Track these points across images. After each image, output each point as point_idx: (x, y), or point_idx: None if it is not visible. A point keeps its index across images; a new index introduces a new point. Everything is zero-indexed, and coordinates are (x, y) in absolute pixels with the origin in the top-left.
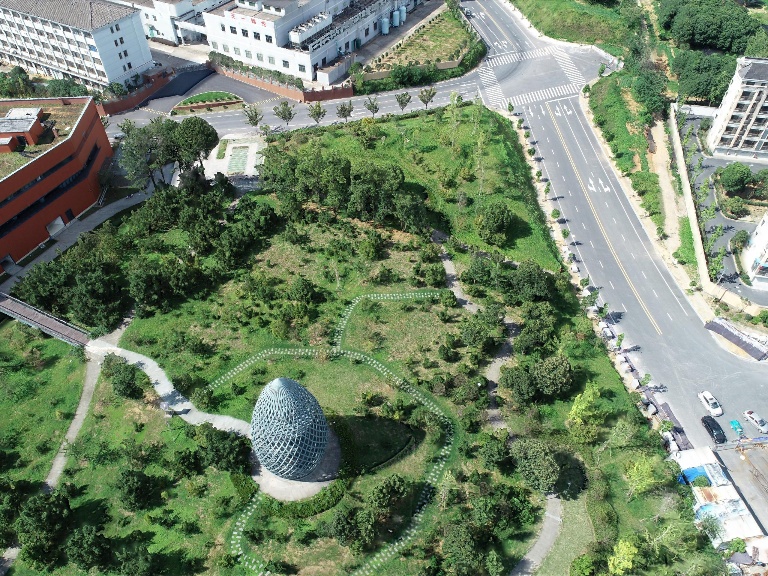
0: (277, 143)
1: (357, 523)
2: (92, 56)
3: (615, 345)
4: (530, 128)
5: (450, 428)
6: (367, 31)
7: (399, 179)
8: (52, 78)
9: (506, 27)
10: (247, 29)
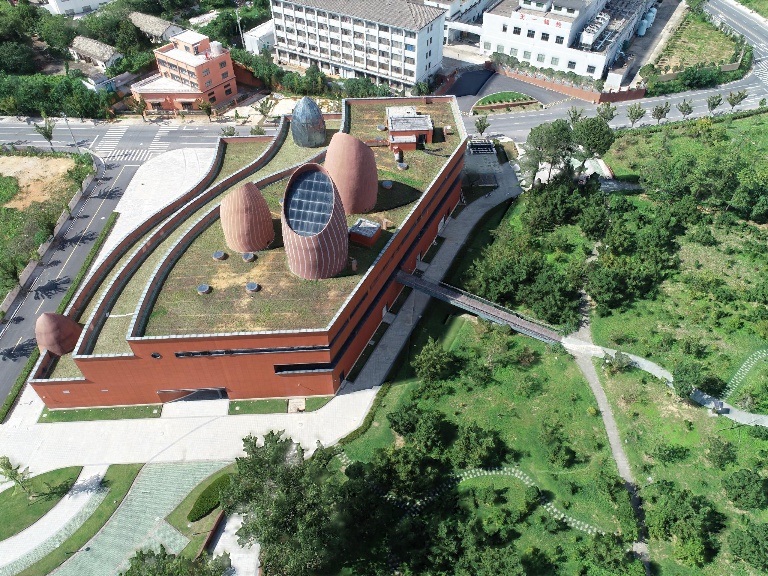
0: None
1: None
2: (405, 55)
3: None
4: None
5: None
6: (629, 33)
7: None
8: (339, 77)
9: (754, 30)
10: (535, 30)
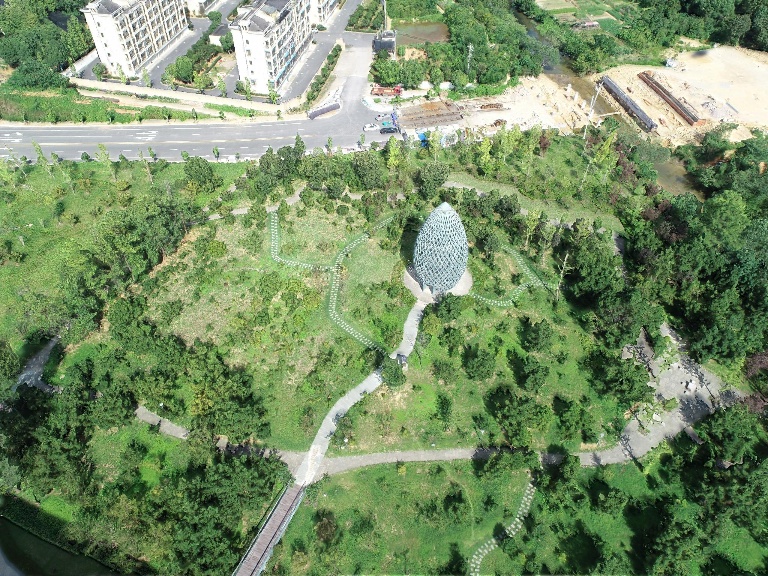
0: None
1: None
2: None
3: (326, 151)
4: (31, 160)
5: None
6: None
7: None
8: None
9: None
10: None
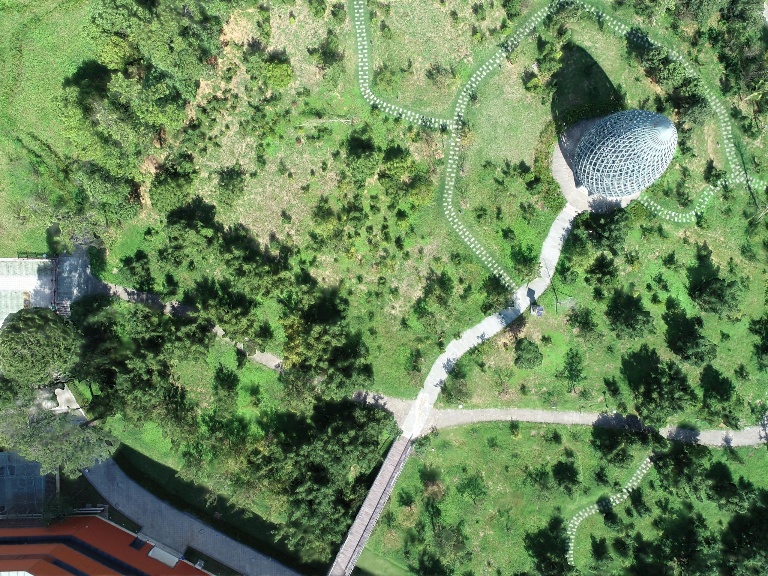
0: None
1: (698, 95)
2: None
3: None
4: None
5: (565, 2)
6: None
7: (134, 5)
8: None
9: None
10: None
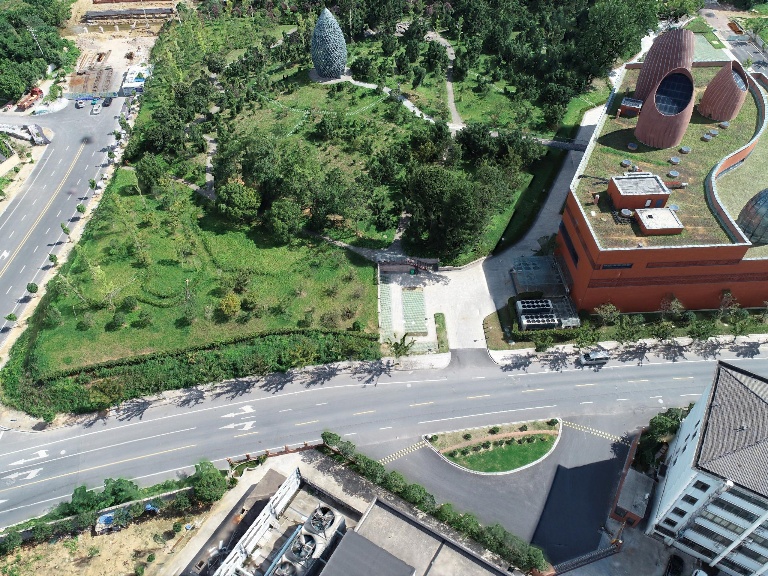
0: (365, 330)
1: None
2: None
3: None
4: None
5: None
6: None
7: None
8: None
9: None
10: None
